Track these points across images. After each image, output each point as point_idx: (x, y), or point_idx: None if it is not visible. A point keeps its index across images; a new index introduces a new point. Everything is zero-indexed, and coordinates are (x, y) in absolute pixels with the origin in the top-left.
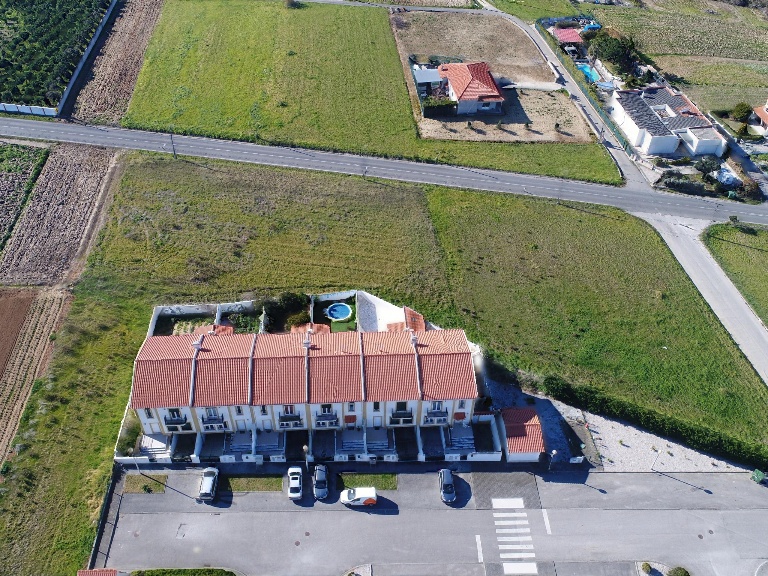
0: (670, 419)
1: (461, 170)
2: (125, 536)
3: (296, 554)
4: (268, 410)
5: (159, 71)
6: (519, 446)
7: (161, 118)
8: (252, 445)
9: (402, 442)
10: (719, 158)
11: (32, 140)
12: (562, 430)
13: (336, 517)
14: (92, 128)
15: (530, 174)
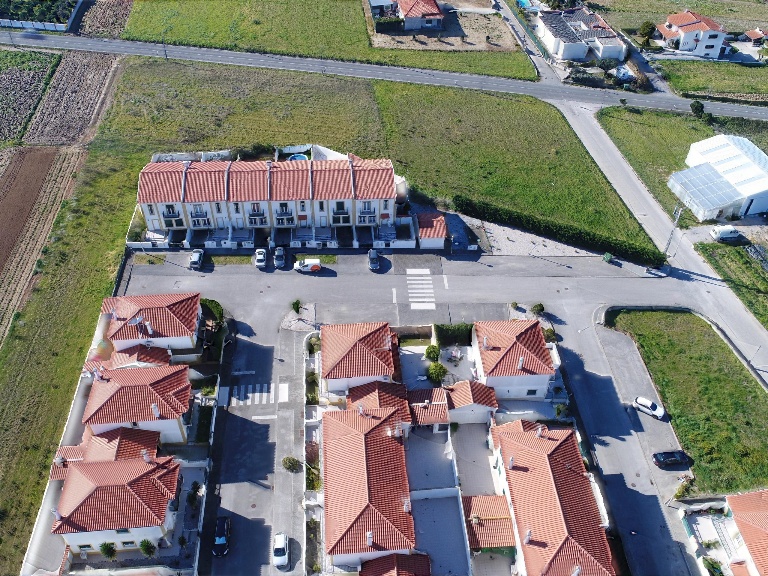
0: (545, 220)
1: (404, 70)
2: (136, 287)
3: (260, 298)
4: (240, 208)
5: None
6: (428, 234)
7: (154, 32)
8: (229, 235)
9: (342, 236)
10: (621, 62)
11: (47, 48)
12: (465, 232)
13: (290, 278)
14: (97, 40)
15: (462, 73)
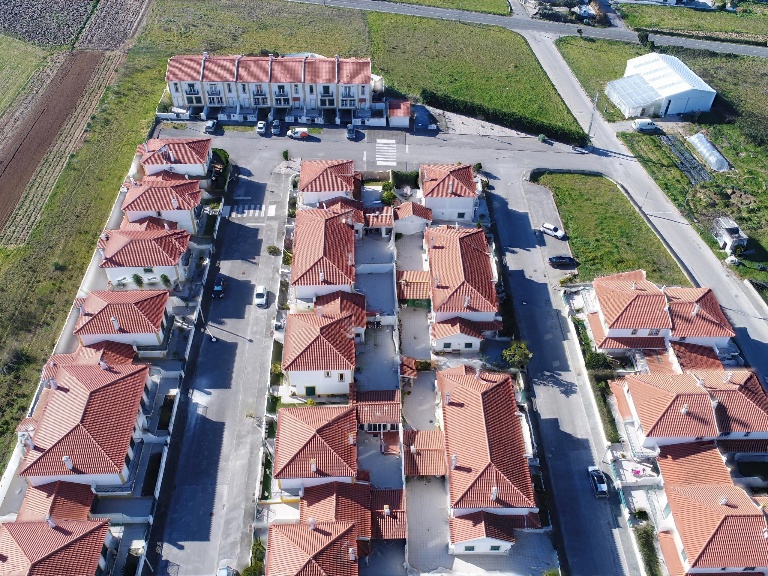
0: (493, 108)
1: (395, 4)
2: None
3: (259, 153)
4: (247, 89)
5: None
6: (396, 113)
7: None
8: (237, 111)
9: (328, 116)
10: (586, 3)
11: None
12: (428, 117)
13: (284, 142)
14: None
15: (444, 8)
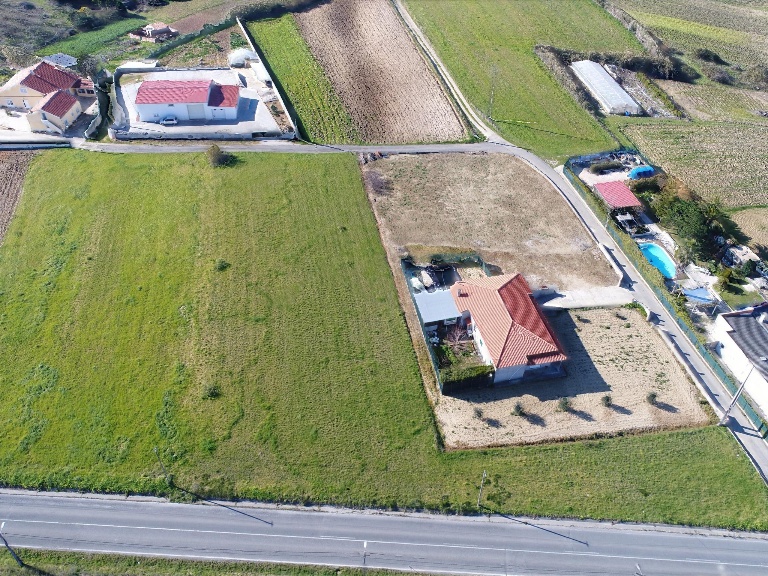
0: None
1: (524, 528)
2: None
3: None
4: None
5: (7, 328)
6: None
7: (1, 451)
8: None
9: None
10: None
11: None
12: None
13: None
14: None
15: (637, 522)
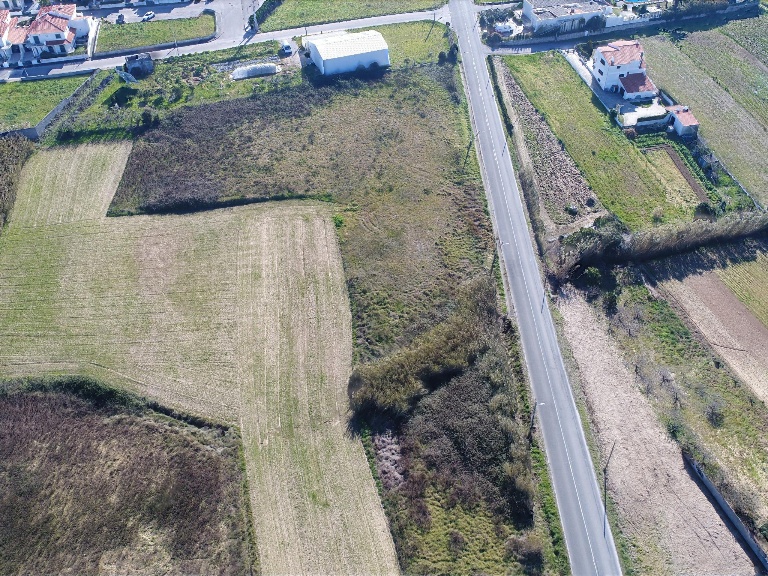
0: None
1: None
2: None
3: None
4: None
5: None
6: None
7: None
8: None
9: None
10: None
11: None
12: None
13: None
14: None
15: None
